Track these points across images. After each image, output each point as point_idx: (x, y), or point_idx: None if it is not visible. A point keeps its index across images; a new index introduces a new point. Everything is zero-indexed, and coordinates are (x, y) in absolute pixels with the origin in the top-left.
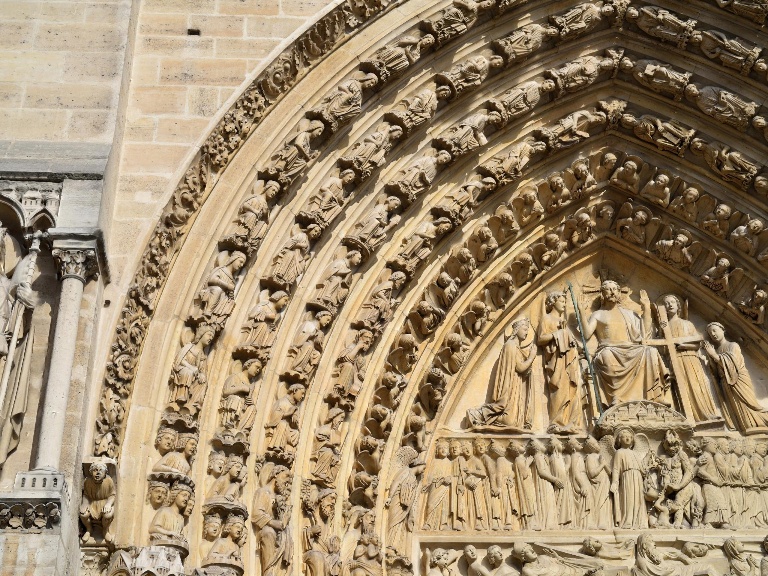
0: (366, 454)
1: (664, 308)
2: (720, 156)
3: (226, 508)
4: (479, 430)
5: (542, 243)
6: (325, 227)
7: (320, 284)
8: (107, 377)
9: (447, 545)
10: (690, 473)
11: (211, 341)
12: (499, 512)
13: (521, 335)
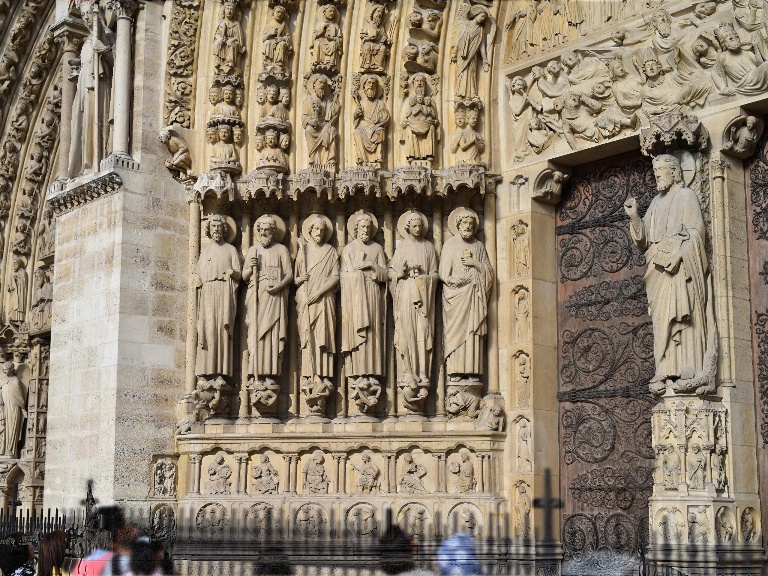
0: (415, 29)
1: None
2: None
3: (261, 128)
4: None
5: None
6: None
7: None
8: (169, 70)
9: (526, 70)
10: None
11: (249, 5)
12: (560, 28)
13: None
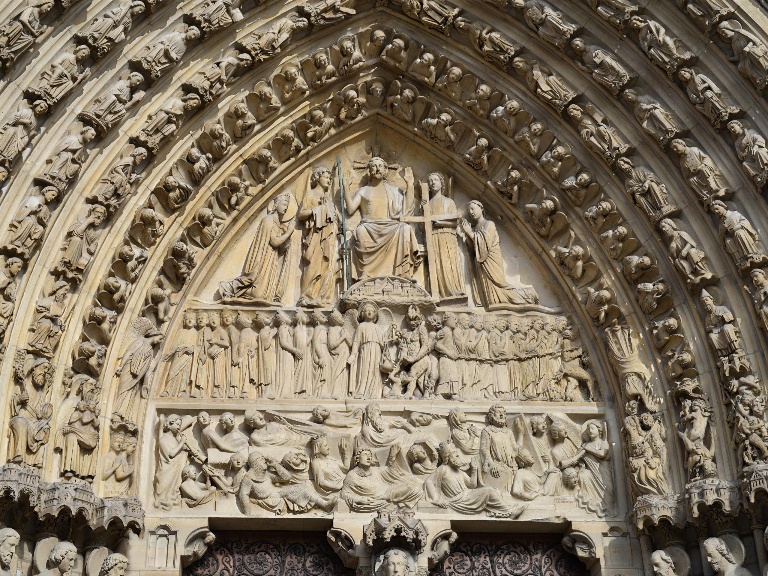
0: (94, 325)
1: (427, 186)
2: (481, 36)
3: None
4: (228, 302)
5: (306, 119)
6: (53, 103)
7: (49, 159)
8: None
9: (183, 411)
10: (426, 347)
11: None
12: (237, 381)
13: (280, 210)
